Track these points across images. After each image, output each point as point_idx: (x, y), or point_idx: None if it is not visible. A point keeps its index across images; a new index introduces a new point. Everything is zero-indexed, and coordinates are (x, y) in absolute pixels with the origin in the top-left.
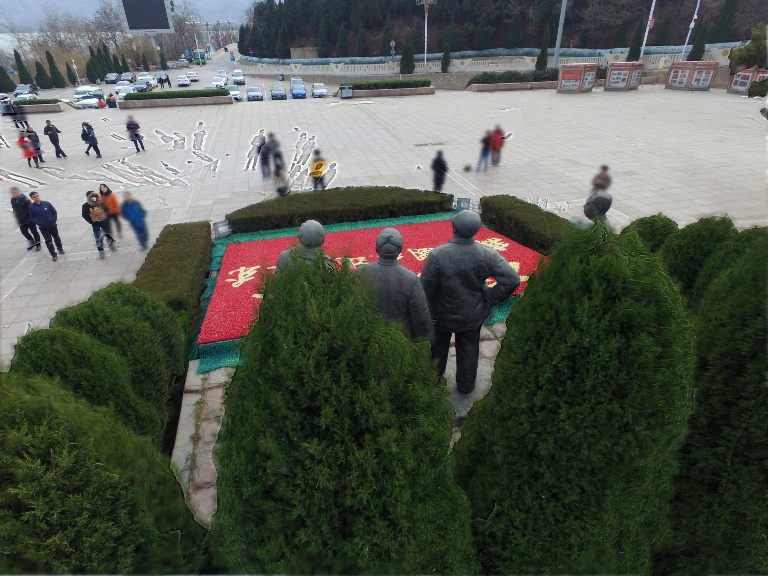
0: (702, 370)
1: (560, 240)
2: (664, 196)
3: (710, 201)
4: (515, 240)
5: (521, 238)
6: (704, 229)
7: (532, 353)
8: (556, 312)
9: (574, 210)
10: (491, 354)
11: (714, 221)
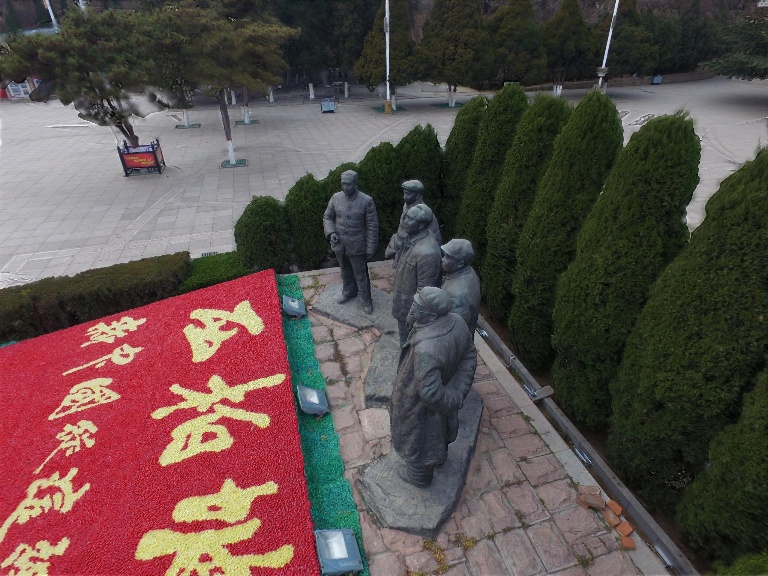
0: (601, 177)
1: (172, 274)
2: (65, 220)
3: (102, 205)
4: (112, 313)
5: (100, 311)
6: (313, 186)
7: (690, 168)
8: (693, 146)
9: (33, 272)
10: (361, 345)
11: (308, 179)
